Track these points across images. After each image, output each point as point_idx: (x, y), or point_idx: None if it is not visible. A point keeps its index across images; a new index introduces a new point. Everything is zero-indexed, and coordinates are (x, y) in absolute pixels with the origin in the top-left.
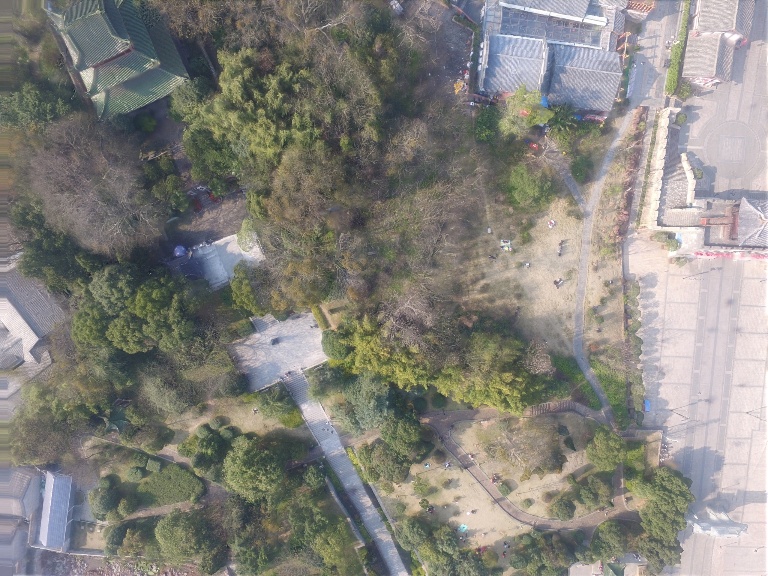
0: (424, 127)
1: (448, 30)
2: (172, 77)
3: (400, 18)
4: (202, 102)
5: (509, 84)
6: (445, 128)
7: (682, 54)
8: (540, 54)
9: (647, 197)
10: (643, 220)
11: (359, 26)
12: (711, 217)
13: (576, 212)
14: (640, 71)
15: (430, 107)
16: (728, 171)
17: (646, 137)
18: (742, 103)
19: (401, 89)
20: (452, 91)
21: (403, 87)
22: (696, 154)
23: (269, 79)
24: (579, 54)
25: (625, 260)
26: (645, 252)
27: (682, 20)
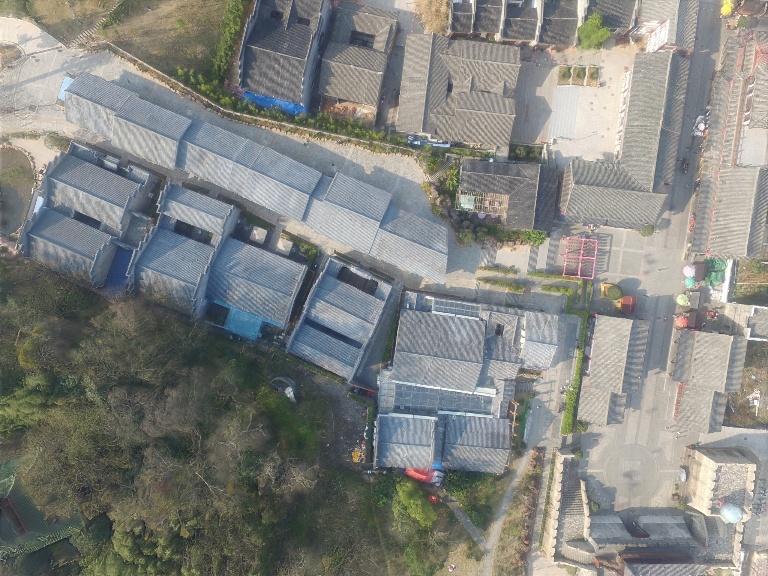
0: (308, 560)
1: (344, 404)
2: (69, 526)
3: (294, 407)
4: (95, 559)
5: (402, 462)
6: (344, 497)
7: (577, 398)
8: (429, 438)
9: (547, 526)
10: (544, 545)
11: (242, 470)
12: (605, 555)
13: (476, 553)
14: (536, 414)
15: (320, 512)
16: (627, 491)
17: (544, 472)
18: (640, 428)
19: (291, 502)
20: (350, 459)
21: (292, 500)
22: (596, 477)
23: (156, 538)
24: (470, 425)
25: (530, 575)
26: (549, 567)
27: (576, 367)
